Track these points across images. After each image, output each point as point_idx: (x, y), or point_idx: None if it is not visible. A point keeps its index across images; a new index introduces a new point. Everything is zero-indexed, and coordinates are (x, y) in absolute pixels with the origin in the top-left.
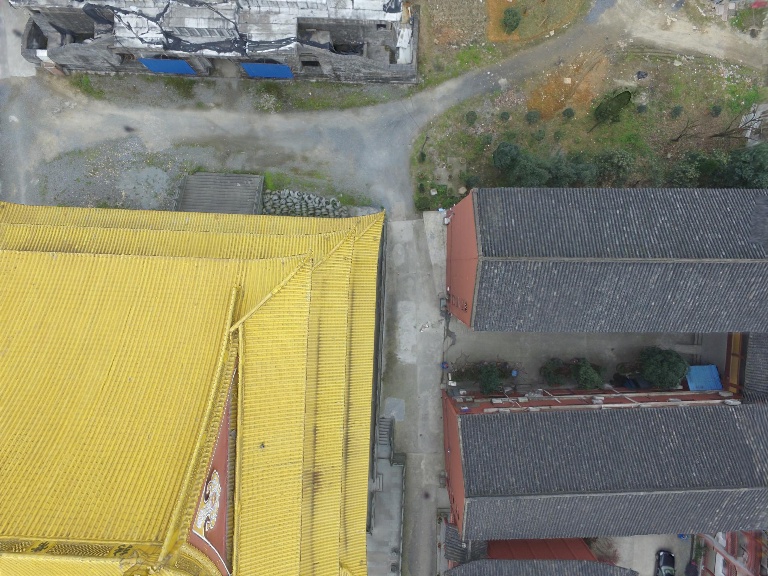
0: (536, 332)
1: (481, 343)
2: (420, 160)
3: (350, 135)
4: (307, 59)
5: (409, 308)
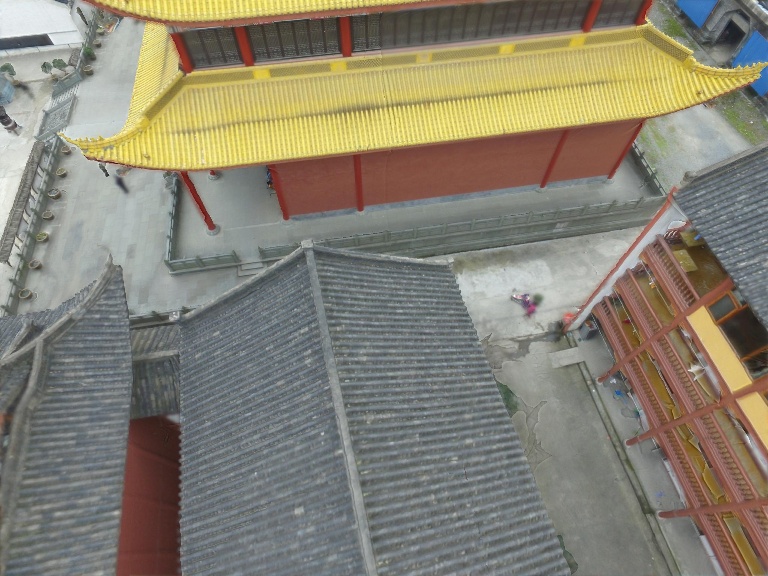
0: (594, 512)
1: (529, 402)
2: None
3: None
4: None
5: (540, 276)
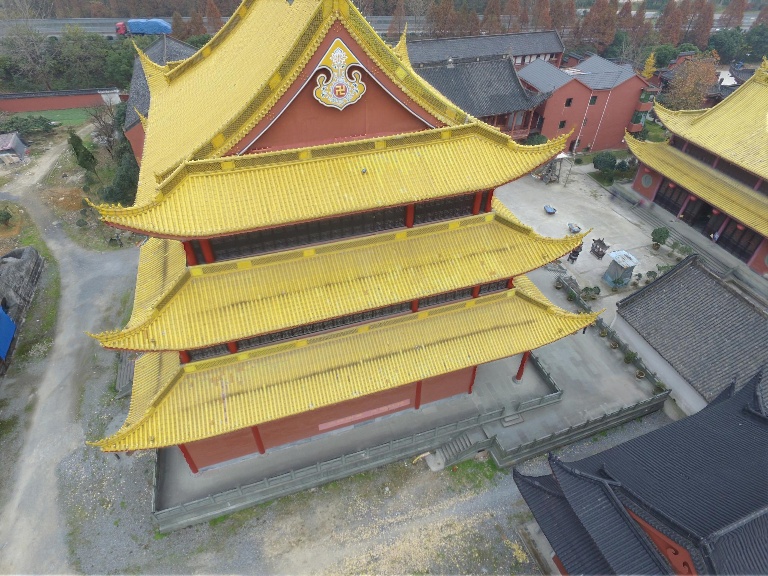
0: None
1: None
2: (116, 244)
3: (87, 286)
4: None
5: None
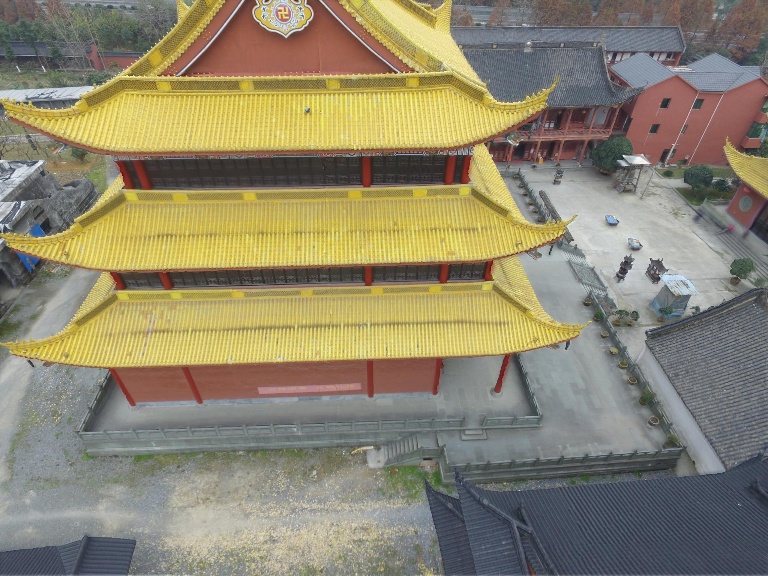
0: None
1: None
2: None
3: None
4: (40, 222)
5: None
